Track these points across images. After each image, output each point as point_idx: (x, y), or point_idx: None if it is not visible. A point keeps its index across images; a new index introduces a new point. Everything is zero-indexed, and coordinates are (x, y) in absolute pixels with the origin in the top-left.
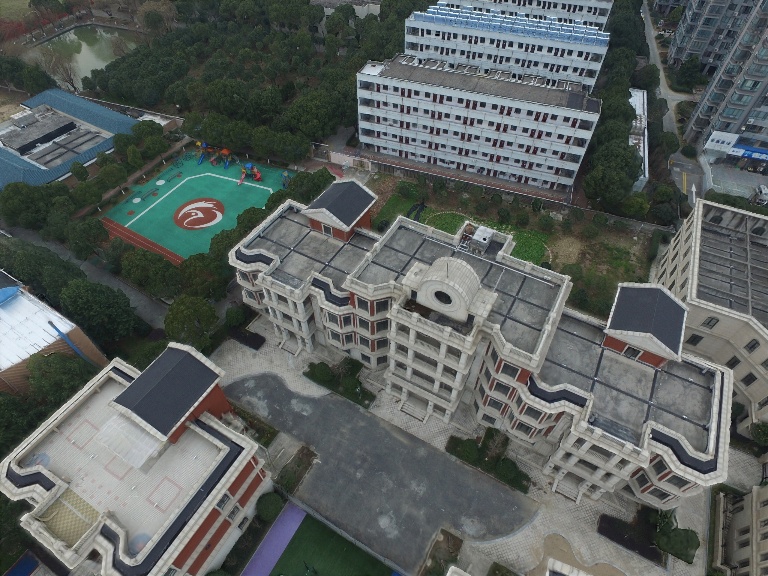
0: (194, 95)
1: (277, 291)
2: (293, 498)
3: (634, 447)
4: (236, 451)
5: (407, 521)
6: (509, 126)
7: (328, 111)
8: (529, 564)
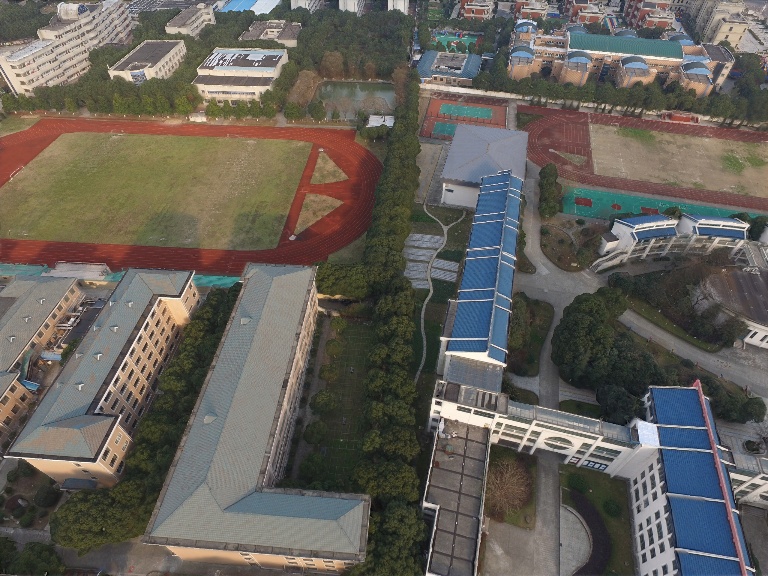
0: None
1: (492, 3)
2: None
3: None
4: None
5: None
6: None
7: None
8: (508, 9)
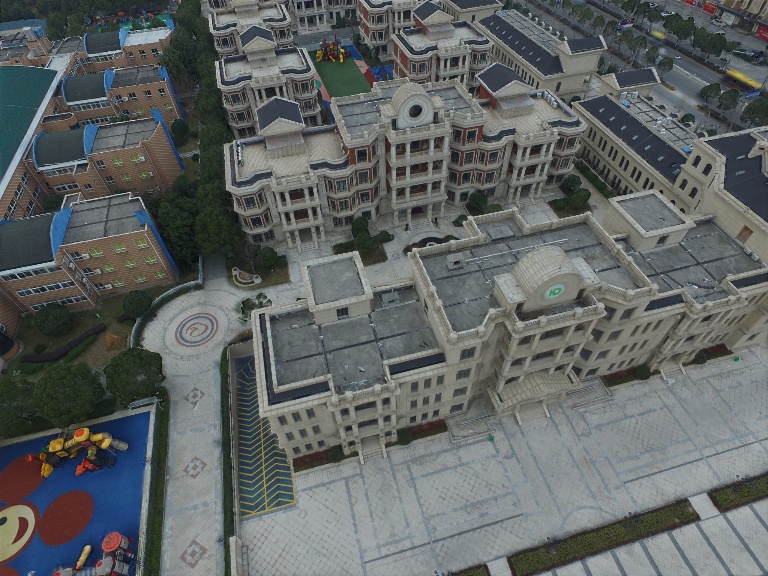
0: None
1: None
2: (300, 46)
3: None
4: (279, 5)
5: None
6: None
7: None
8: None
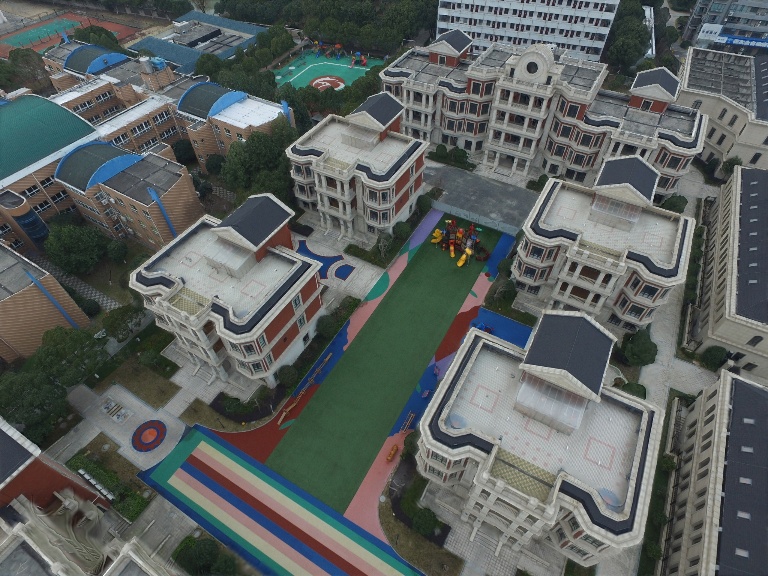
0: (309, 9)
1: (417, 89)
2: None
3: (648, 137)
4: (419, 143)
5: (507, 215)
6: (553, 16)
7: (415, 14)
8: None
